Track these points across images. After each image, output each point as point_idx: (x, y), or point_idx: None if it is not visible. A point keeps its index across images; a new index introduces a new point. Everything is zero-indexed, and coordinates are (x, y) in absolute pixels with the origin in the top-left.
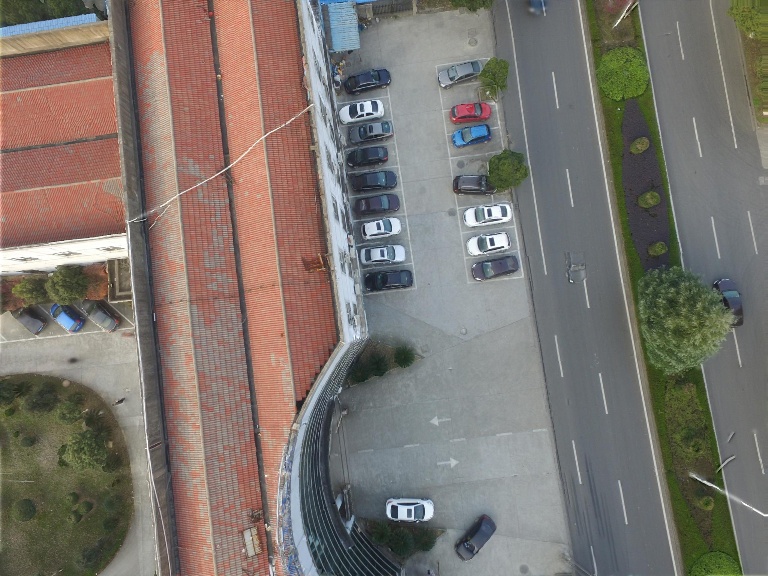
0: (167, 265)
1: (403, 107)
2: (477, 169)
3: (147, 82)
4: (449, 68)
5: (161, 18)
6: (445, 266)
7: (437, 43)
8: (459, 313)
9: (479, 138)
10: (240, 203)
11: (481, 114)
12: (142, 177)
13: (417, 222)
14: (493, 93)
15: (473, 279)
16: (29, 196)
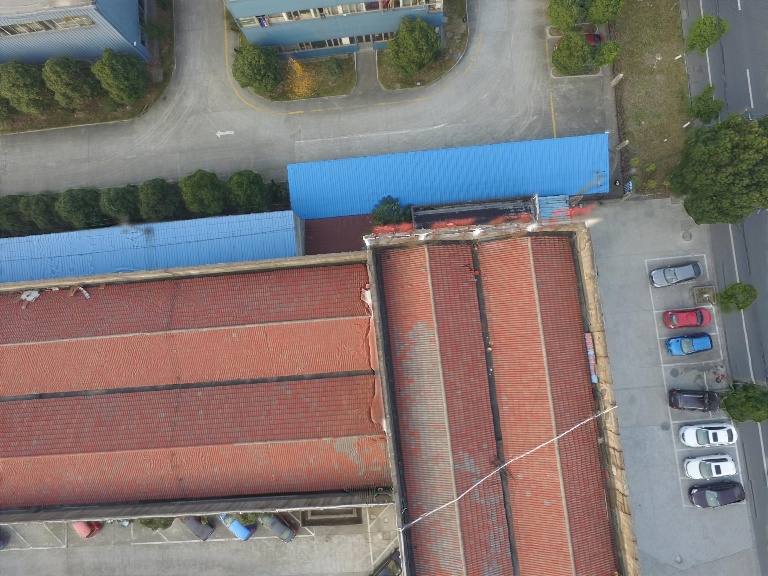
0: (439, 574)
1: (610, 305)
2: (693, 379)
3: (409, 354)
4: (662, 265)
5: (431, 287)
6: (658, 486)
7: (647, 234)
8: (674, 539)
9: (701, 350)
10: (519, 502)
11: (702, 322)
12: (400, 460)
13: (626, 435)
14: (711, 295)
15: (690, 503)
16: (249, 449)
